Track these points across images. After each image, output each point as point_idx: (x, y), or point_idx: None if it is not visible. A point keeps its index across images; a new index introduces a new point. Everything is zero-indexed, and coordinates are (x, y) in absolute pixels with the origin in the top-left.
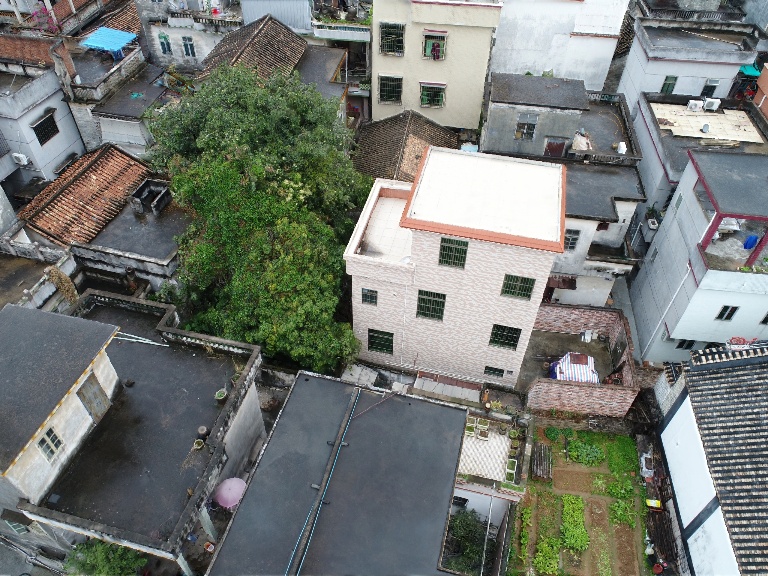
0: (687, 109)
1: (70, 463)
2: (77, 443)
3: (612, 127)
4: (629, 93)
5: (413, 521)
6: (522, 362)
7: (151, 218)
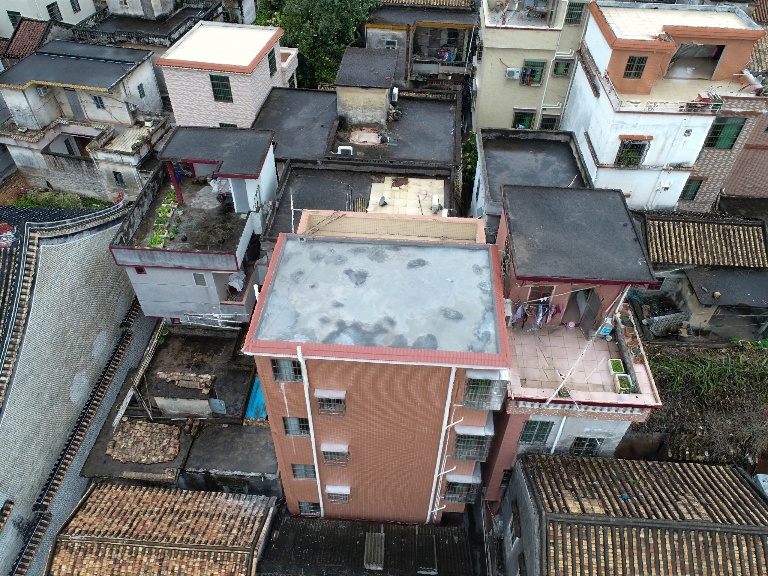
0: None
1: (129, 17)
2: (134, 14)
3: None
4: None
5: (57, 76)
6: None
7: None
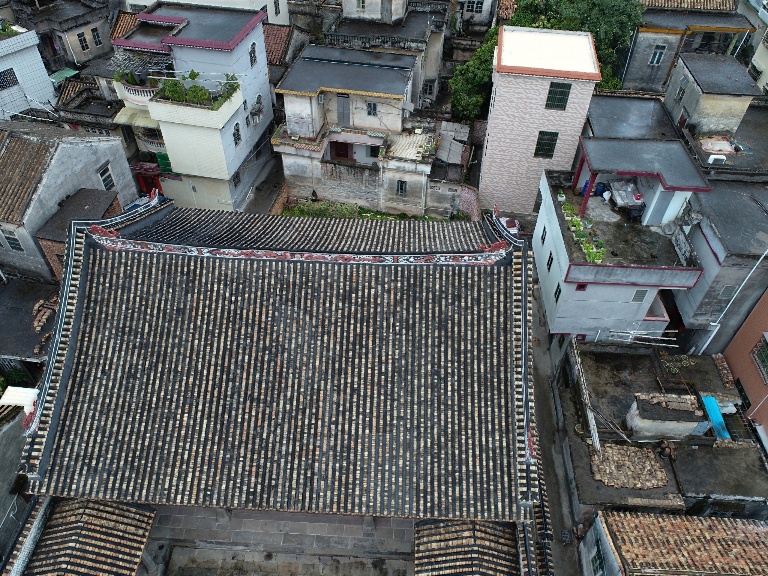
0: None
1: (363, 21)
2: (370, 18)
3: None
4: None
5: (341, 83)
6: (511, 215)
7: None
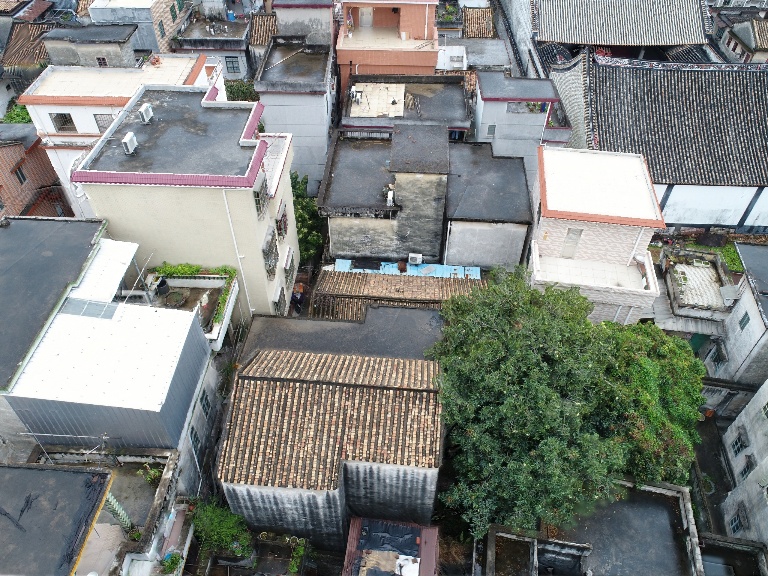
0: (359, 104)
1: None
2: None
3: (381, 146)
4: (304, 134)
5: None
6: None
7: (594, 560)
